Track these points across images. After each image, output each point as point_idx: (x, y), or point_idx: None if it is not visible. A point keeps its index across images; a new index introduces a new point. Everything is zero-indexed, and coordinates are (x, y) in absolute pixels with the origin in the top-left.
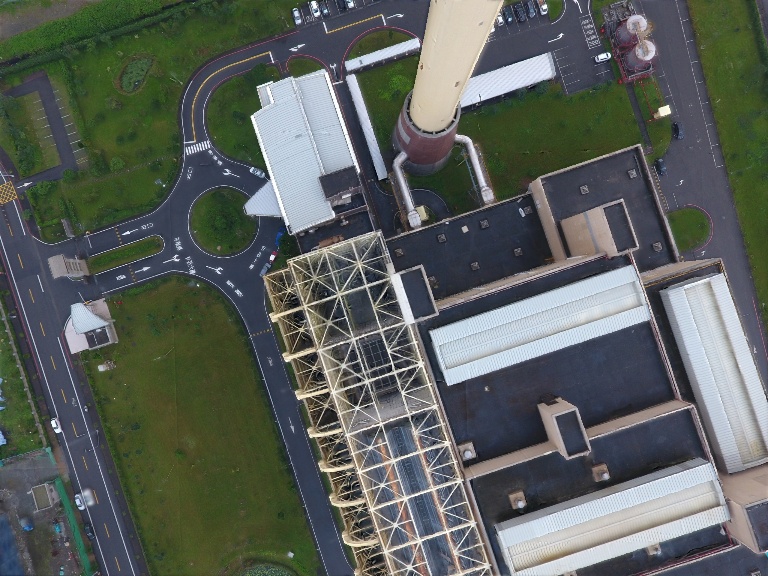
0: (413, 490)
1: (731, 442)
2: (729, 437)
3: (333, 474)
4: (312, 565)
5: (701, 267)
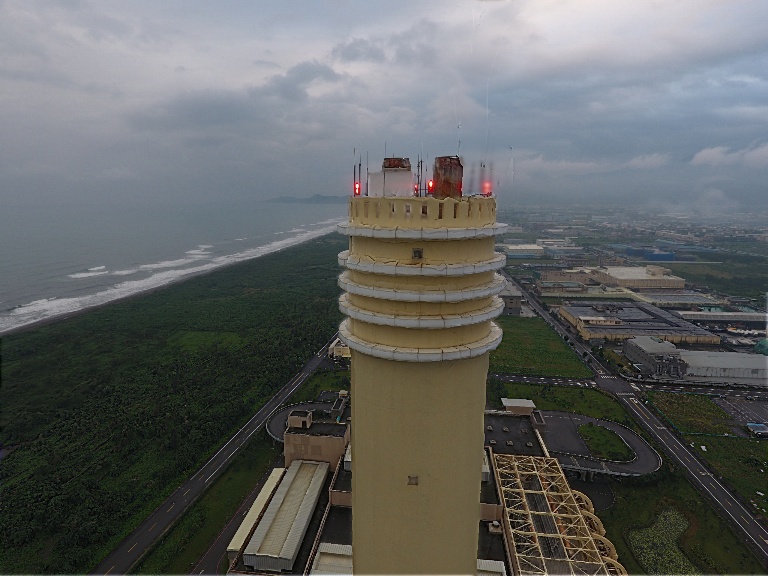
0: (542, 530)
1: (318, 473)
2: (317, 476)
3: (615, 573)
4: (632, 574)
5: (247, 573)
